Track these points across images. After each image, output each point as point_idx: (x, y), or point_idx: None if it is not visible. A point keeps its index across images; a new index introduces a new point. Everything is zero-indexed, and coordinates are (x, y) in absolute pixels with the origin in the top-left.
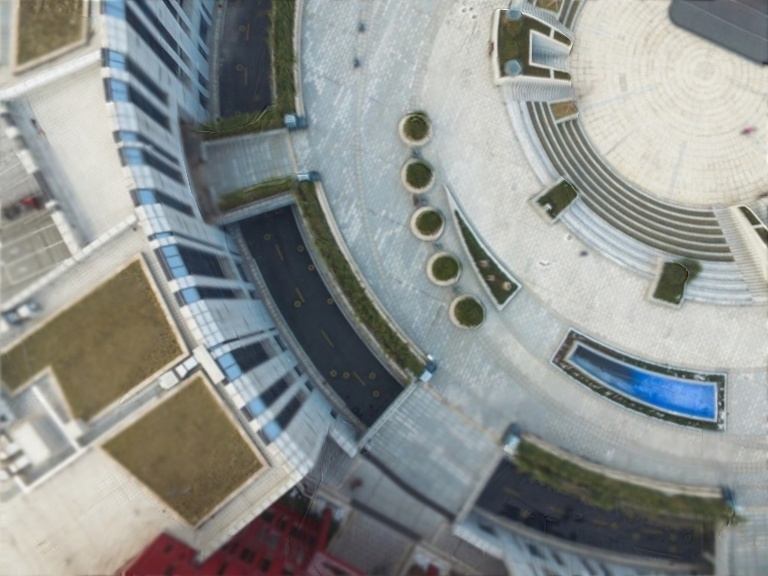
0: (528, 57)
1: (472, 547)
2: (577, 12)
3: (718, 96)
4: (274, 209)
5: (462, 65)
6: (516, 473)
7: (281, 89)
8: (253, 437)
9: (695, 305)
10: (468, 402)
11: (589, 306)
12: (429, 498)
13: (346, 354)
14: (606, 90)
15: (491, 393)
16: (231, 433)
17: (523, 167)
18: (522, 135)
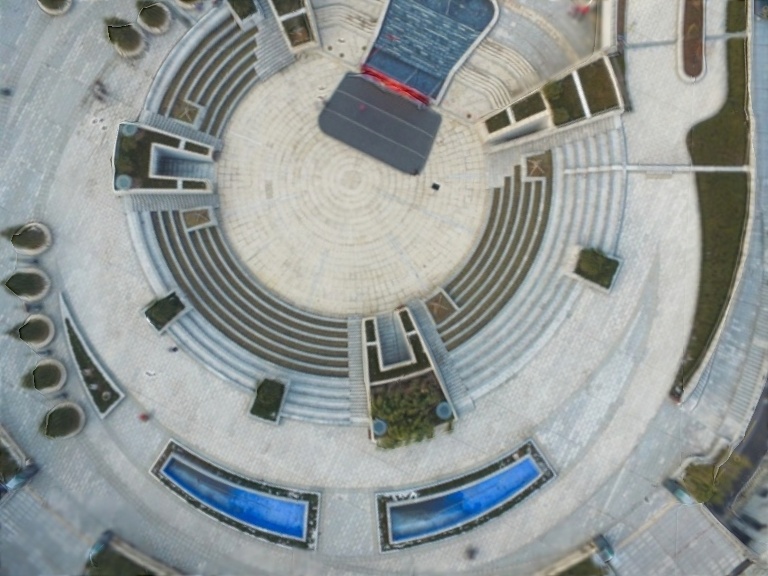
0: (148, 170)
1: None
2: (225, 120)
3: (363, 205)
4: None
5: (88, 175)
6: None
7: None
8: None
9: (293, 423)
10: (67, 507)
11: (191, 418)
12: None
13: None
14: (252, 197)
15: (90, 499)
16: None
17: (138, 277)
18: (139, 246)
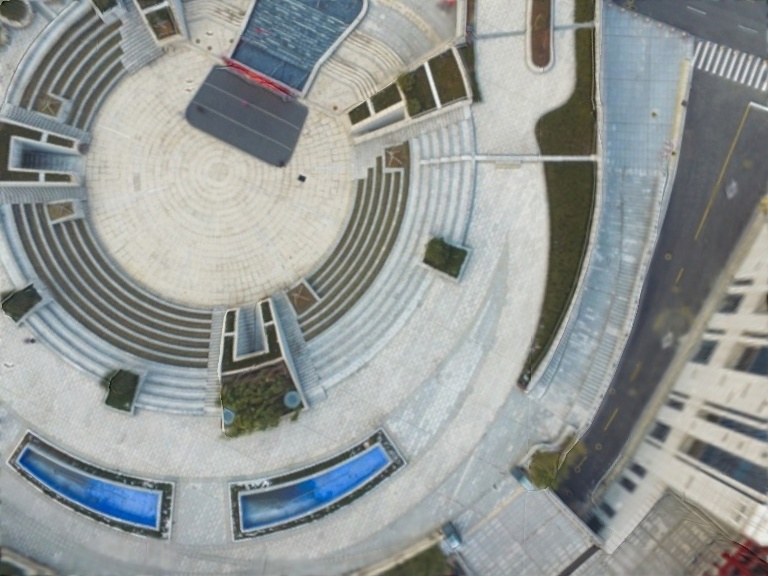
0: (7, 163)
1: None
2: (92, 113)
3: (230, 197)
4: None
5: None
6: None
7: None
8: None
9: (147, 413)
10: None
11: (48, 409)
12: None
13: None
14: (120, 189)
15: None
16: None
17: None
18: None
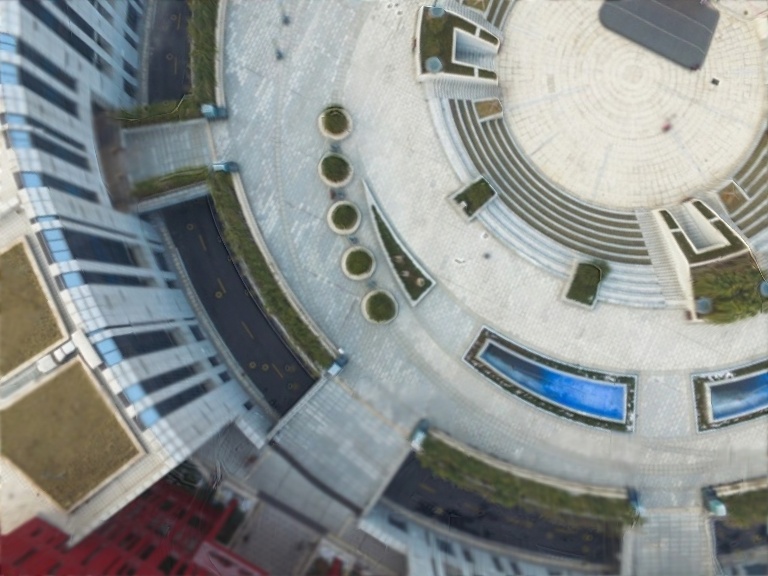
0: (451, 55)
1: (376, 541)
2: (507, 12)
3: (645, 100)
4: (192, 199)
5: (385, 61)
6: (421, 468)
7: (198, 78)
8: (130, 423)
9: (608, 307)
10: (379, 397)
11: (503, 305)
12: (337, 491)
13: (264, 346)
14: (534, 90)
15: (402, 388)
16: (108, 418)
17: (442, 164)
18: (443, 132)
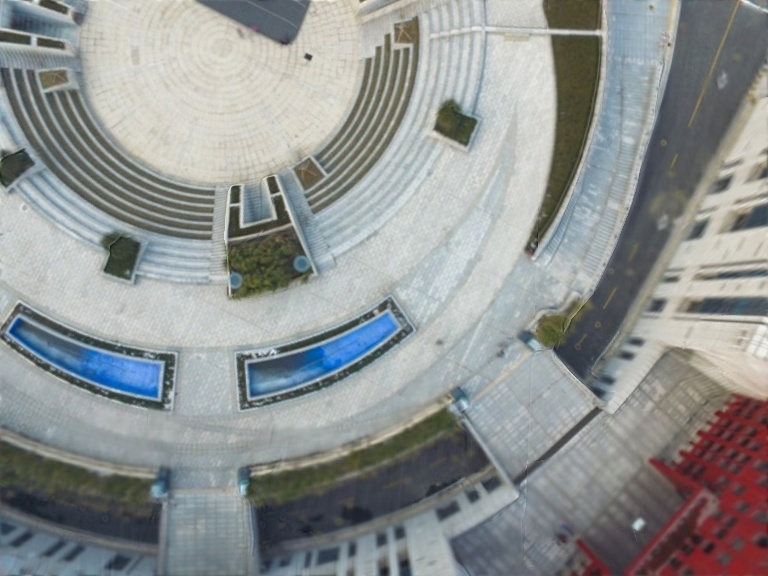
0: None
1: None
2: None
3: (234, 74)
4: None
5: None
6: None
7: None
8: None
9: (149, 281)
10: None
11: (41, 279)
12: None
13: None
14: (117, 62)
15: None
16: None
17: None
18: None
